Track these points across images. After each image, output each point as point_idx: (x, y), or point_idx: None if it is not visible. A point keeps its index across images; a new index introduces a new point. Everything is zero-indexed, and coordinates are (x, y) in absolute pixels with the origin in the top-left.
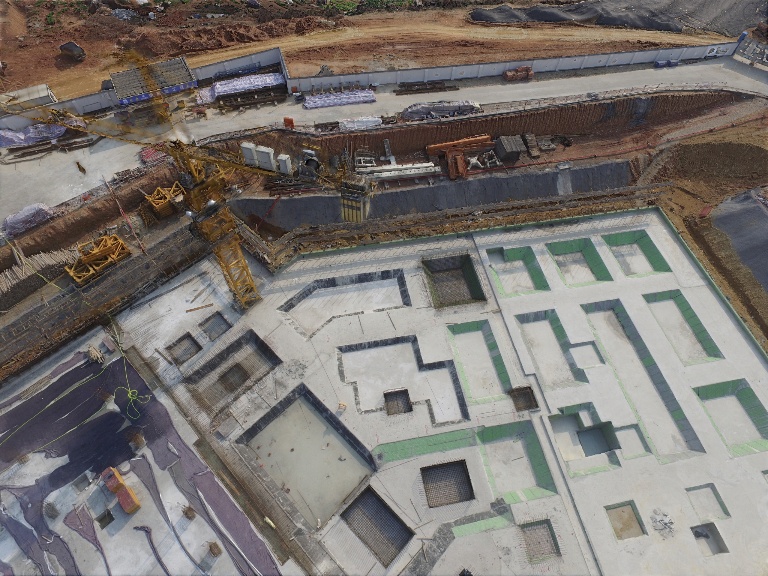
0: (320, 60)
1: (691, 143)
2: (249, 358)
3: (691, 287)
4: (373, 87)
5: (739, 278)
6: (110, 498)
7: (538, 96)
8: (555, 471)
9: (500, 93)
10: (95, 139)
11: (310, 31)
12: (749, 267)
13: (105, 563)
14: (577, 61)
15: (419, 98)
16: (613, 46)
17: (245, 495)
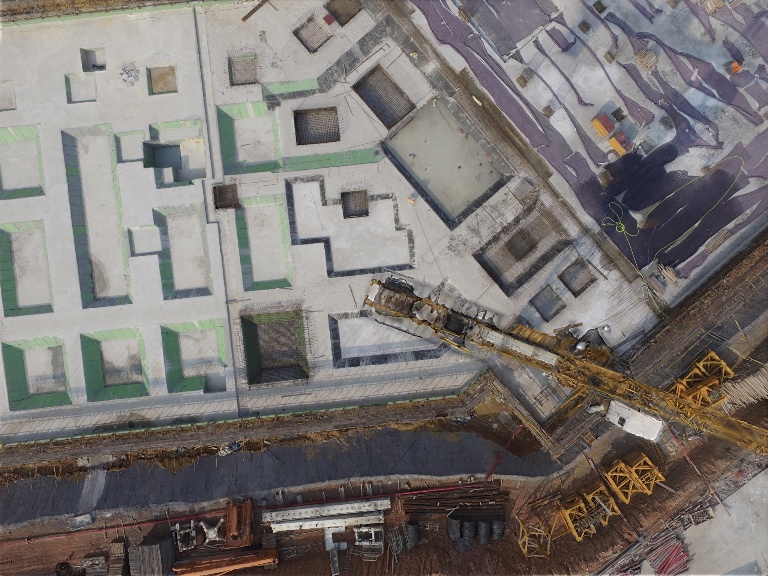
0: None
1: None
2: (508, 266)
3: None
4: None
5: None
6: None
7: None
8: (214, 126)
9: None
10: None
11: None
12: None
13: (611, 81)
14: None
15: None
16: None
17: (501, 125)
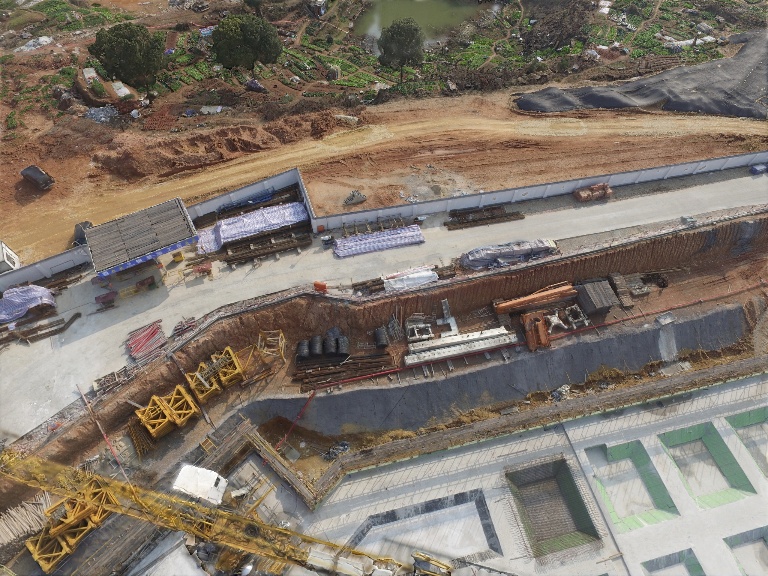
0: (346, 177)
1: None
2: None
3: None
4: (419, 221)
5: None
6: None
7: (623, 224)
8: None
9: (575, 221)
10: (67, 320)
11: (329, 132)
12: None
13: None
14: (660, 171)
15: (477, 234)
16: (693, 143)
17: None
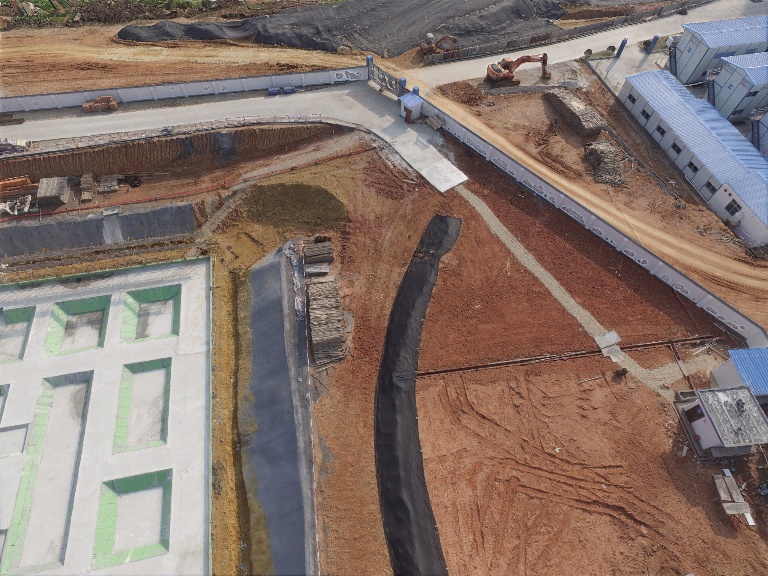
0: None
1: (266, 183)
2: None
3: (187, 354)
4: None
5: (242, 344)
6: None
7: (107, 131)
8: None
9: (66, 127)
10: None
11: None
12: (252, 331)
13: None
14: (175, 89)
15: None
16: (245, 69)
17: None
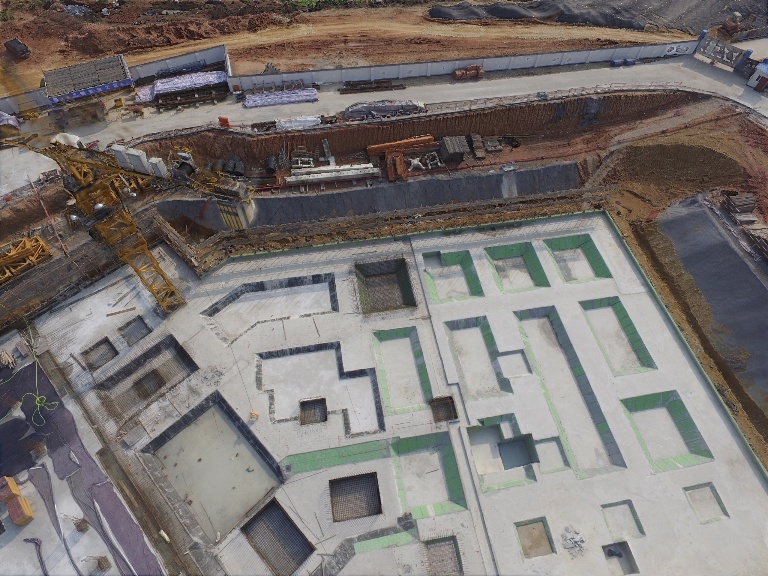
0: (268, 58)
1: (642, 145)
2: (167, 364)
3: (630, 294)
4: (316, 86)
5: (681, 285)
6: (3, 508)
7: (486, 95)
8: (468, 485)
9: (447, 92)
10: (26, 138)
11: (263, 28)
12: (691, 274)
13: None
14: (530, 59)
15: (363, 97)
16: (571, 44)
17: (143, 507)
